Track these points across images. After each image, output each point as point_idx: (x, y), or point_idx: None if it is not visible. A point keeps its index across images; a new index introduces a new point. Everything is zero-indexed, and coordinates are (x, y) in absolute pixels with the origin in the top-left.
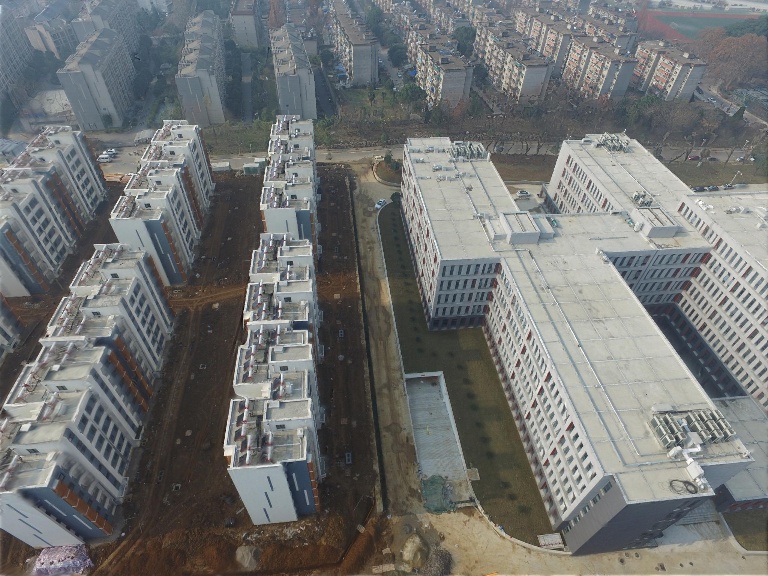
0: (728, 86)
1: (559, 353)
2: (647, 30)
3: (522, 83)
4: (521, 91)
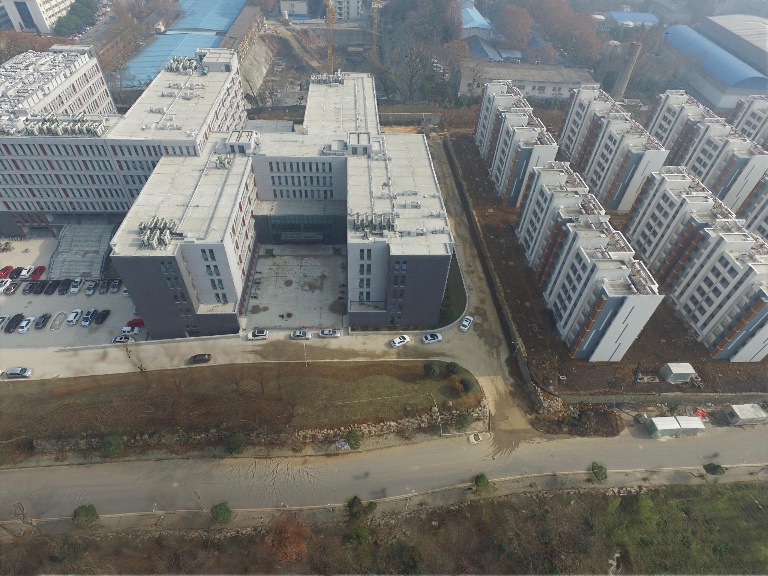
0: None
1: (369, 100)
2: None
3: None
4: None
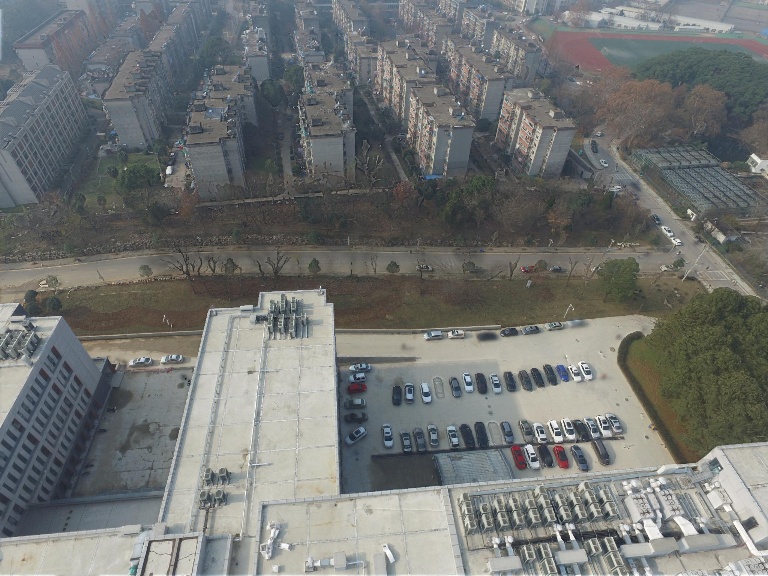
0: (631, 142)
1: None
2: (564, 60)
3: (312, 157)
4: (314, 166)
